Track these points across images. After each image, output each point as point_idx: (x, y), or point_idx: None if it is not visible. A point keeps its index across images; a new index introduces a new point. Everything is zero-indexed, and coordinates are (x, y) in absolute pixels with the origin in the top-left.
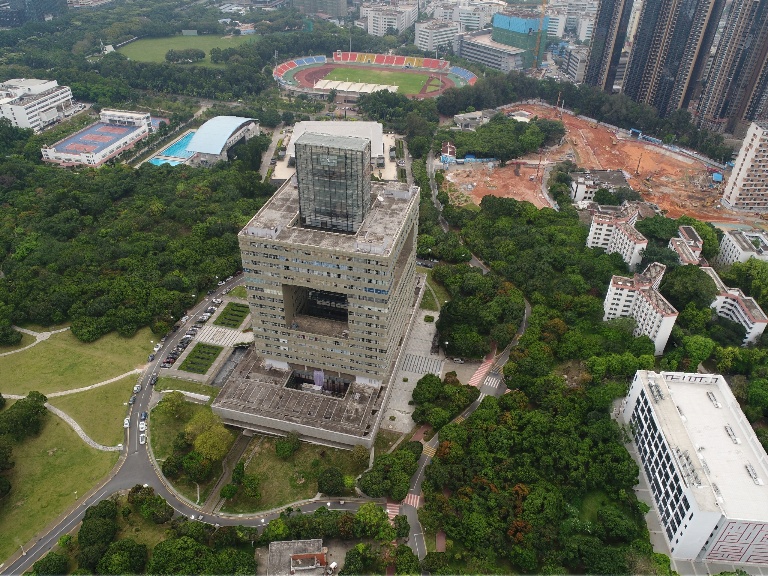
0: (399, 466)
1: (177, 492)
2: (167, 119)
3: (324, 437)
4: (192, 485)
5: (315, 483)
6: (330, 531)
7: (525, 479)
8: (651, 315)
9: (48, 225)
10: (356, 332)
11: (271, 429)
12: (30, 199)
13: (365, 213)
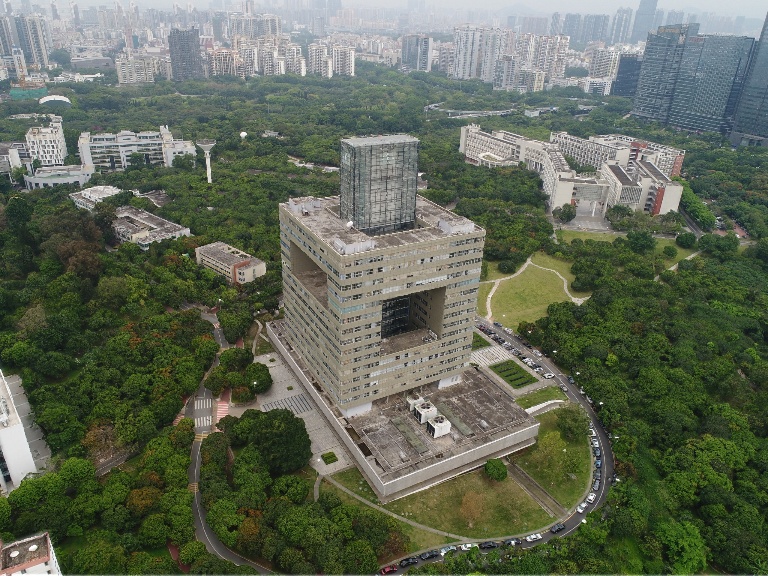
0: None
1: None
2: None
3: None
4: None
5: None
6: None
7: None
8: None
9: None
10: None
11: None
12: None
13: None
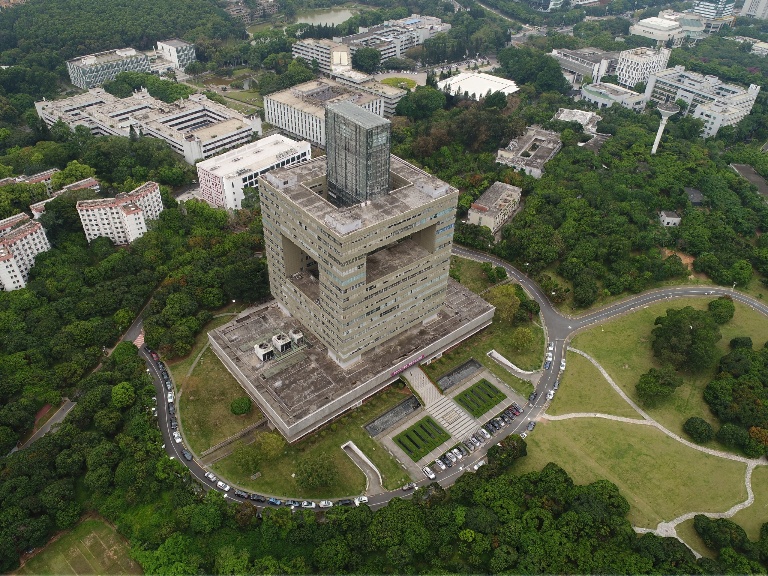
0: None
1: None
2: None
3: None
4: None
5: None
6: None
7: None
8: None
9: None
10: None
11: None
12: None
13: None
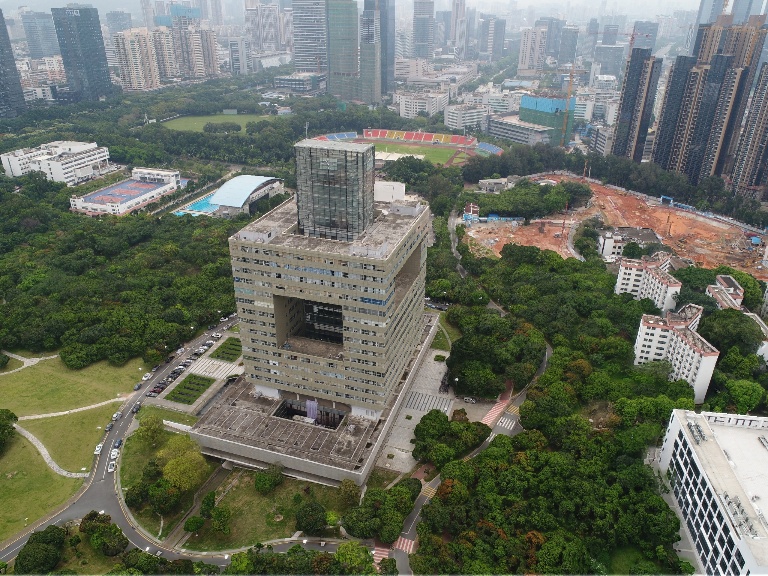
0: (391, 503)
1: (138, 524)
2: (197, 180)
3: (310, 471)
4: (156, 517)
5: (295, 521)
6: (302, 571)
7: (540, 526)
8: (688, 356)
9: (60, 261)
10: (351, 351)
11: (253, 461)
12: (49, 240)
13: (366, 224)
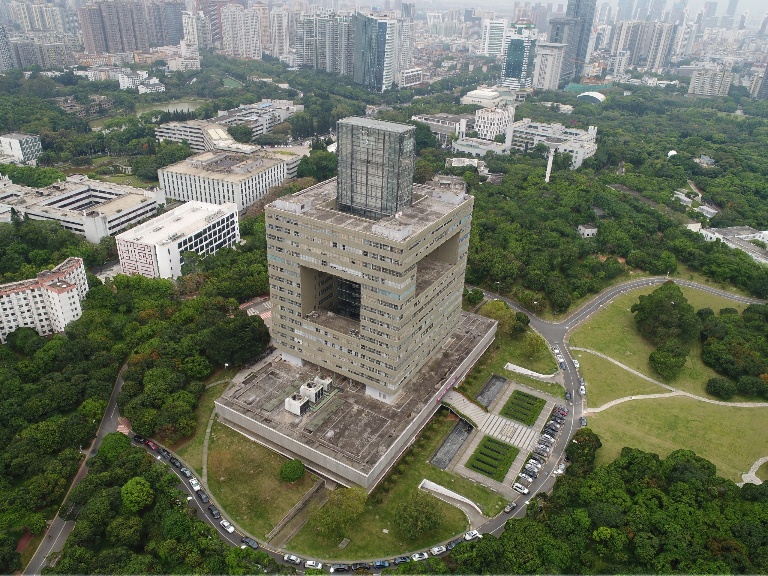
0: None
1: None
2: None
3: None
4: None
5: None
6: None
7: None
8: None
9: None
10: None
11: None
12: None
13: None
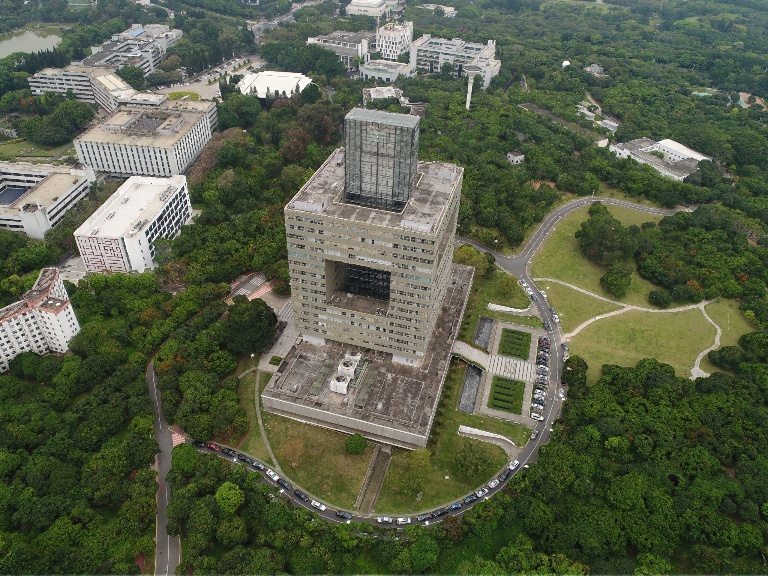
0: None
1: None
2: None
3: None
4: None
5: None
6: None
7: None
8: None
9: None
10: None
11: None
12: None
13: None
